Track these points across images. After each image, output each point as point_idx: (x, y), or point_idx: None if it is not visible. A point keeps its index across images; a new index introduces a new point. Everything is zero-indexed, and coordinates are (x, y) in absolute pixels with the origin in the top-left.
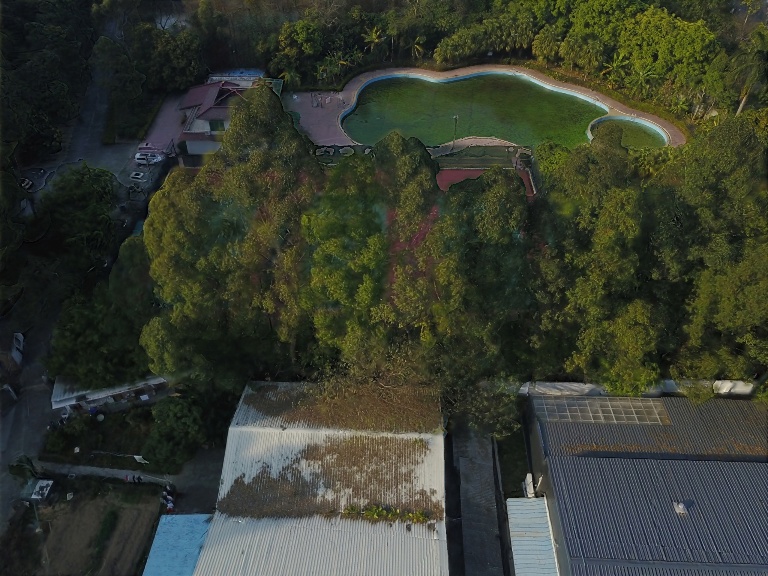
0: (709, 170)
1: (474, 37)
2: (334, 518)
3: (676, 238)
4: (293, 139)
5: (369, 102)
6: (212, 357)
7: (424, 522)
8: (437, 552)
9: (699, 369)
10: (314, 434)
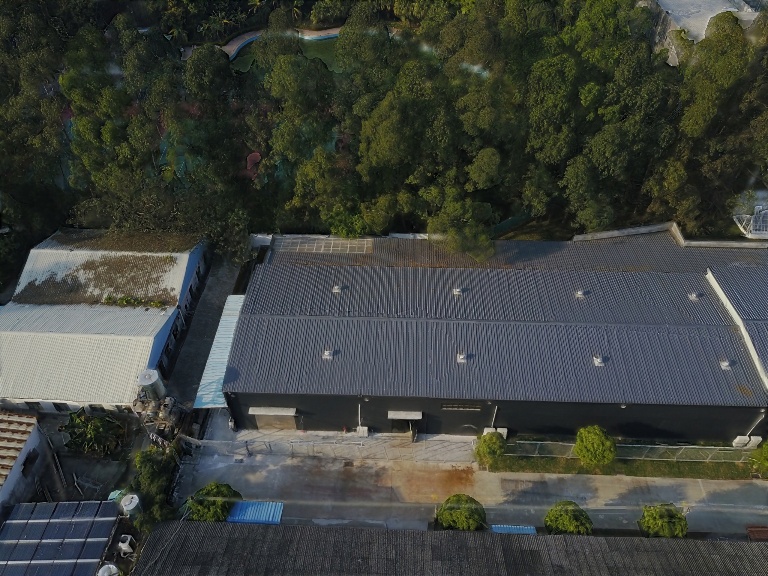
0: (344, 41)
1: (343, 0)
2: (95, 304)
3: (345, 100)
4: (31, 11)
5: (247, 55)
6: (24, 202)
7: (160, 307)
8: (159, 320)
9: (378, 203)
10: (93, 254)
